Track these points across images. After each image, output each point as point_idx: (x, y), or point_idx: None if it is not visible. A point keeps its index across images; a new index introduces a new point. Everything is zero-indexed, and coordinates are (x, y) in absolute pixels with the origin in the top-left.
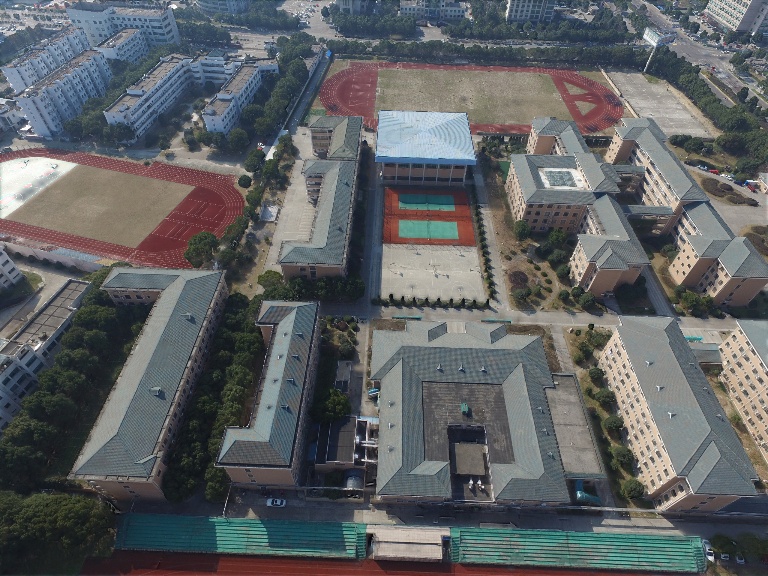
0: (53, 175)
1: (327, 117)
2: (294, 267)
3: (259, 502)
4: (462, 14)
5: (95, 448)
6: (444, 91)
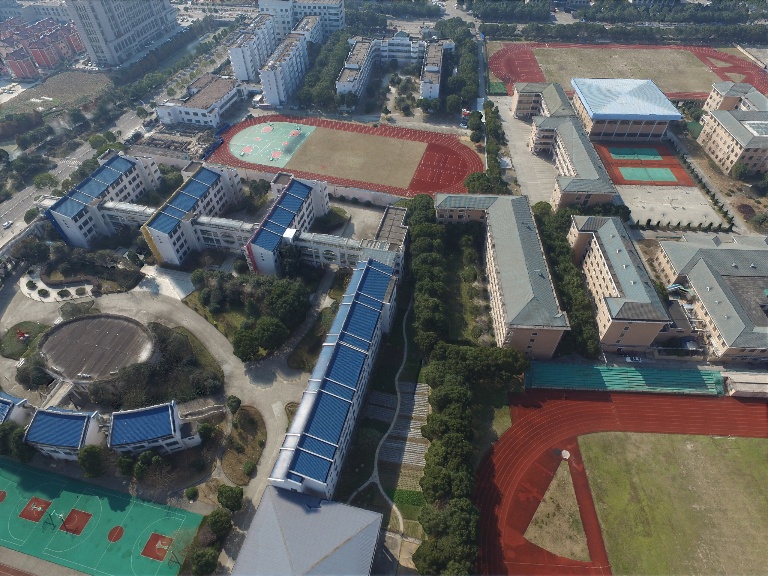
0: (302, 135)
1: (533, 83)
2: (573, 195)
3: (619, 360)
4: (588, 0)
5: (518, 307)
6: (601, 66)
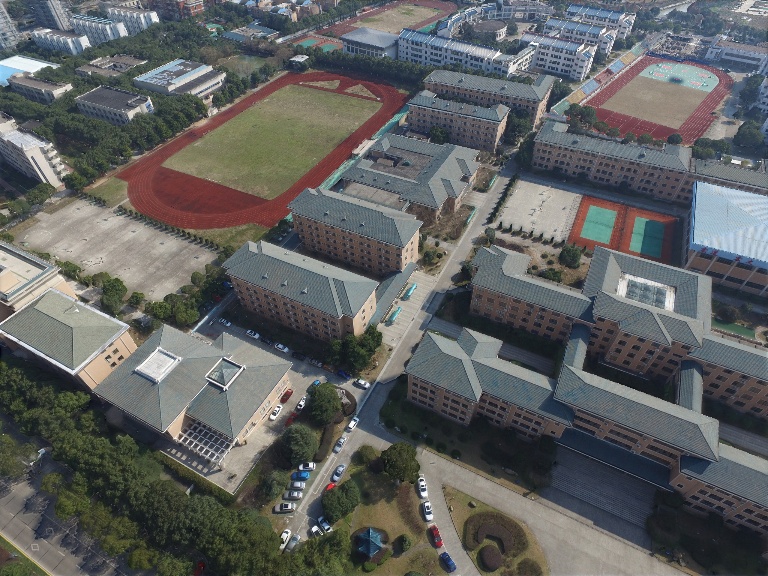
0: (692, 85)
1: None
2: None
3: None
4: None
5: None
6: None
